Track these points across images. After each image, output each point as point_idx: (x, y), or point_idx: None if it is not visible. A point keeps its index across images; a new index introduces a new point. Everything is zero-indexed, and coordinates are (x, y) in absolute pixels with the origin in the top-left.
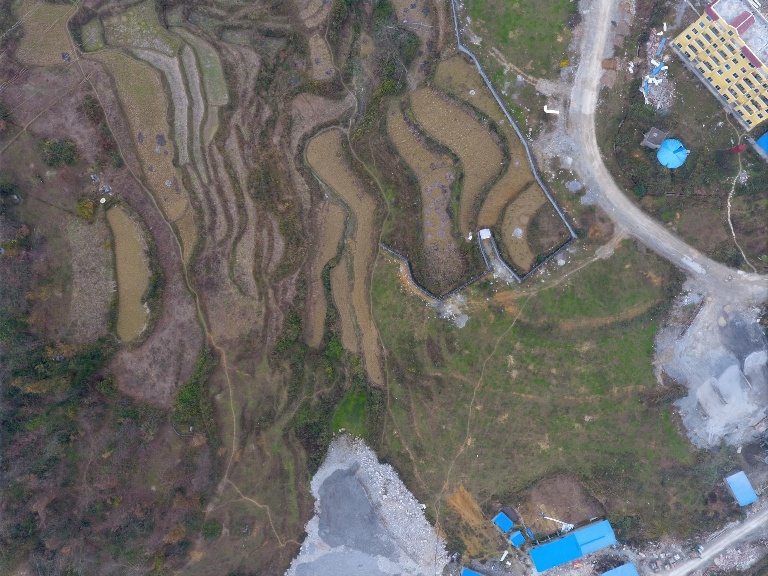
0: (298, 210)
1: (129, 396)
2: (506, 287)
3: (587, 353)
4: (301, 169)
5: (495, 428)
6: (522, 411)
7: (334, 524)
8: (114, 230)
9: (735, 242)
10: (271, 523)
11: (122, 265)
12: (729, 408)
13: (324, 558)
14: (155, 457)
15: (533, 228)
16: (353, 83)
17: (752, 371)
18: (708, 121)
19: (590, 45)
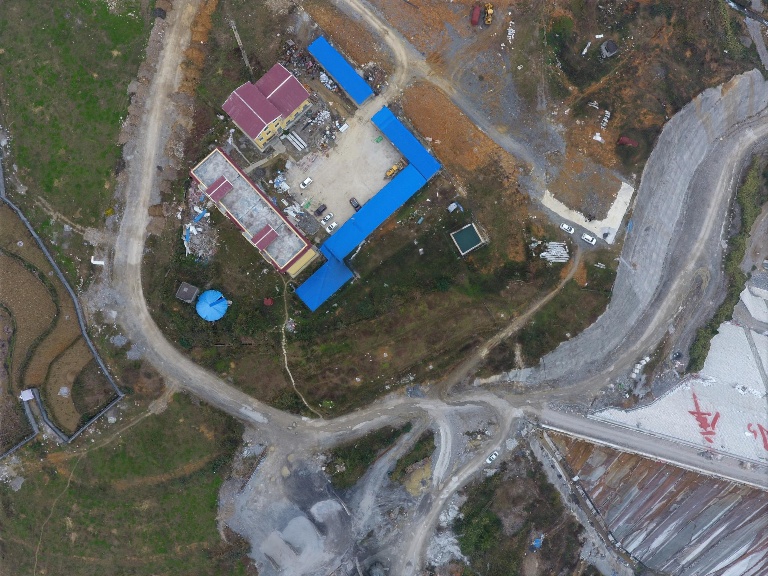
0: None
1: None
2: (56, 448)
3: (147, 511)
4: None
5: None
6: (87, 573)
7: None
8: None
9: (295, 389)
10: None
11: None
12: (305, 558)
13: None
14: None
15: (77, 387)
16: None
17: (328, 517)
18: (252, 268)
19: (136, 192)
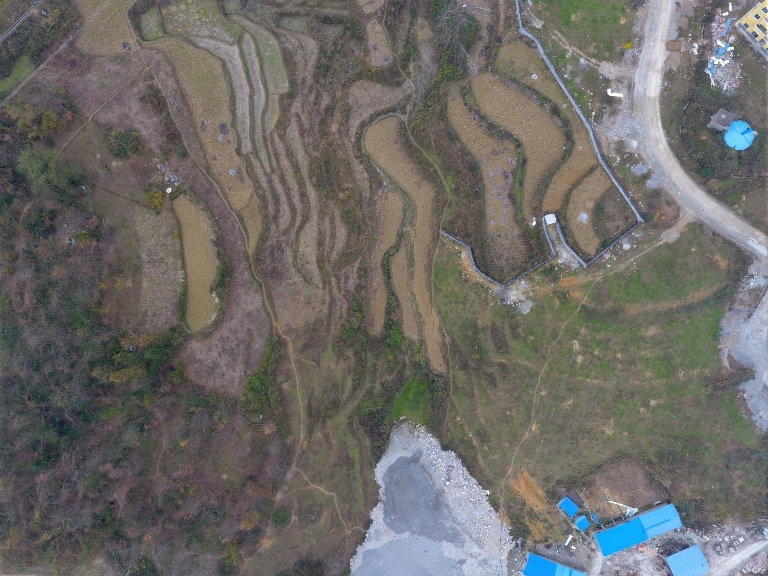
0: (358, 198)
1: (199, 385)
2: (571, 272)
3: (653, 337)
4: (360, 157)
5: (560, 413)
6: (587, 396)
7: (399, 511)
8: (181, 220)
9: None
10: (338, 510)
11: (189, 255)
12: None
13: (390, 544)
14: (225, 446)
15: (599, 212)
16: (410, 69)
17: None
18: None
19: (654, 27)
